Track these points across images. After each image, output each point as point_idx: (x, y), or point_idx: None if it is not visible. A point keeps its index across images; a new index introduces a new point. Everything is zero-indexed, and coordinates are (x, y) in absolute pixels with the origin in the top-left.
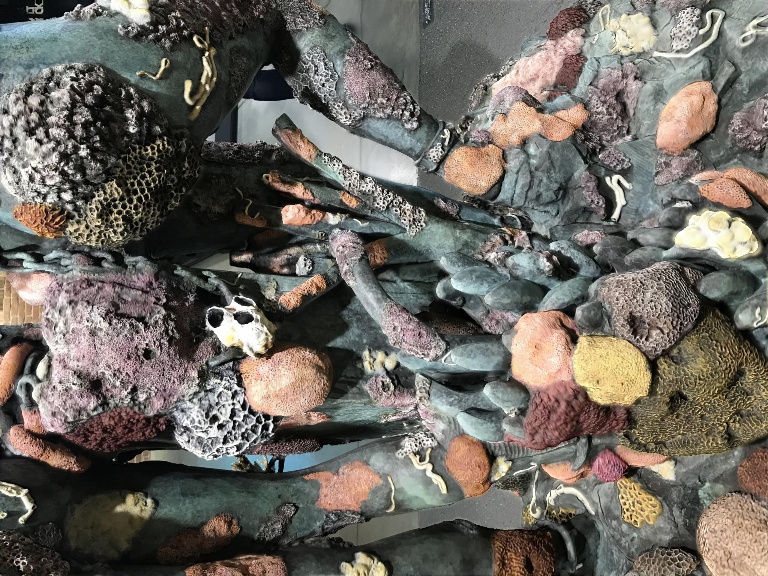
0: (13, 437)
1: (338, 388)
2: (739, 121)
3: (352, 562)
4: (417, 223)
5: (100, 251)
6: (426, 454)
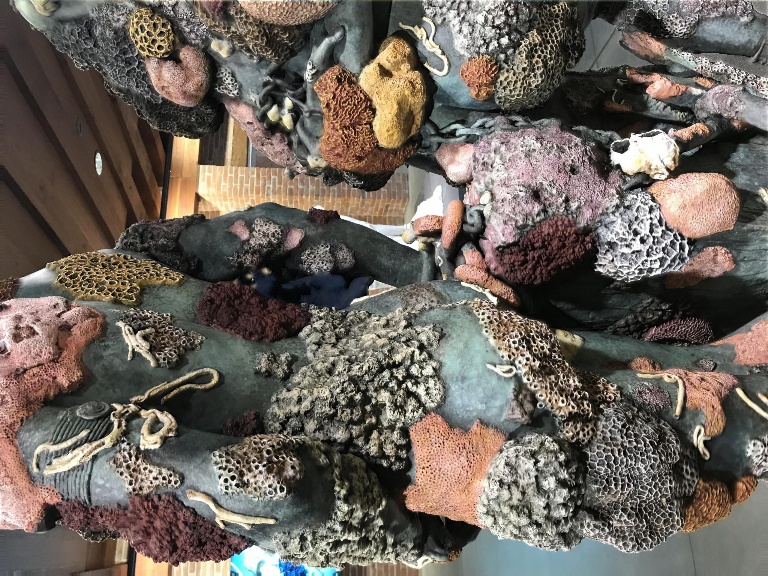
0: (462, 269)
1: (744, 216)
2: None
3: None
4: None
5: (513, 115)
6: None
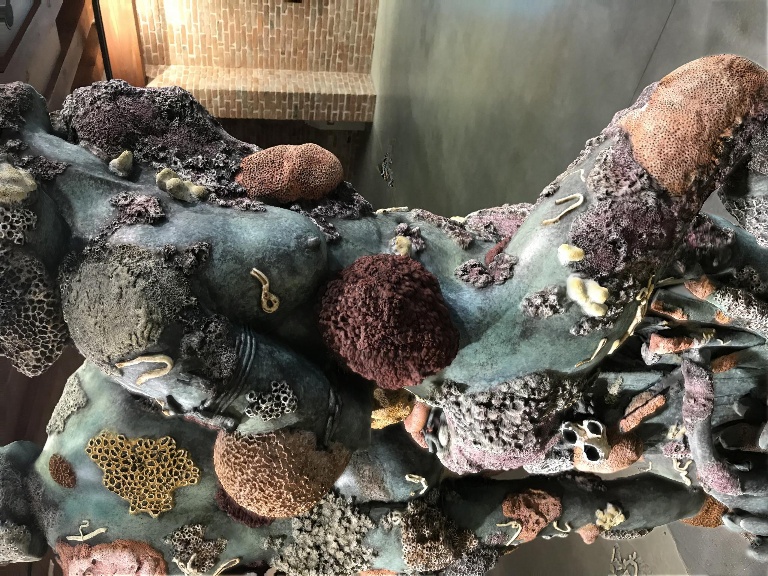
0: (413, 437)
1: None
2: None
3: (604, 510)
4: None
5: None
6: (686, 463)
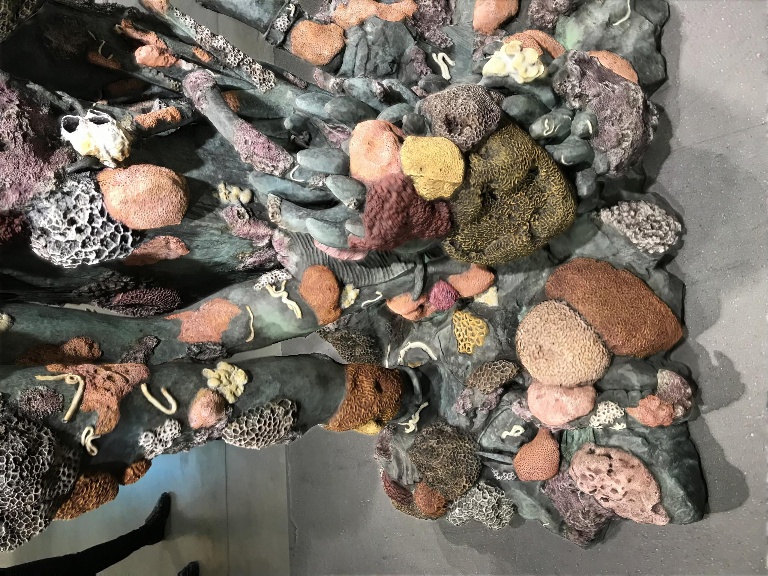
0: None
1: (195, 211)
2: (536, 4)
3: (213, 369)
4: (267, 82)
5: None
6: (282, 285)
